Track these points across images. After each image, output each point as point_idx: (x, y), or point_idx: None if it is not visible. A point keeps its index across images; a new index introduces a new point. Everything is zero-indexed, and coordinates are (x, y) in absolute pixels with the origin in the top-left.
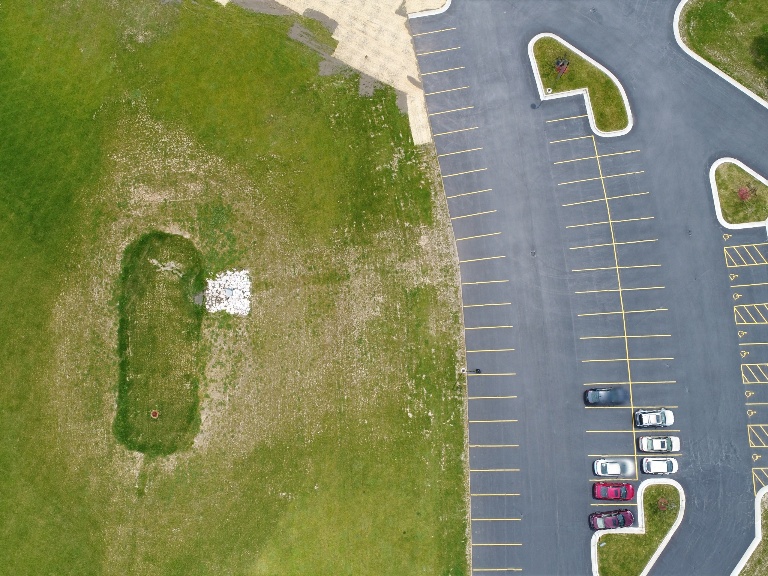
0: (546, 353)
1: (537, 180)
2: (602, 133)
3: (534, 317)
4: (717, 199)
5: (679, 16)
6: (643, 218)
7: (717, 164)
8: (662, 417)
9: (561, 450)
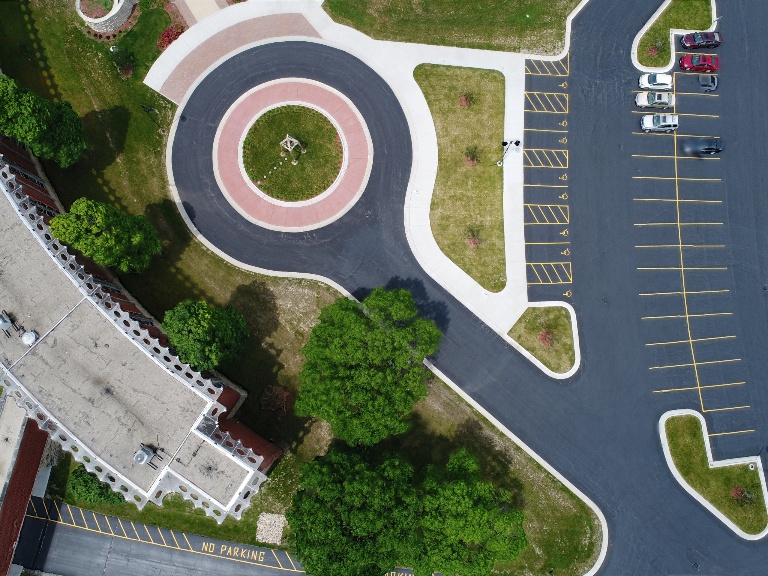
0: (755, 190)
1: (763, 366)
2: (694, 414)
3: (766, 225)
4: (575, 334)
5: (601, 552)
6: (653, 318)
7: (571, 372)
8: (656, 122)
9: (743, 102)
